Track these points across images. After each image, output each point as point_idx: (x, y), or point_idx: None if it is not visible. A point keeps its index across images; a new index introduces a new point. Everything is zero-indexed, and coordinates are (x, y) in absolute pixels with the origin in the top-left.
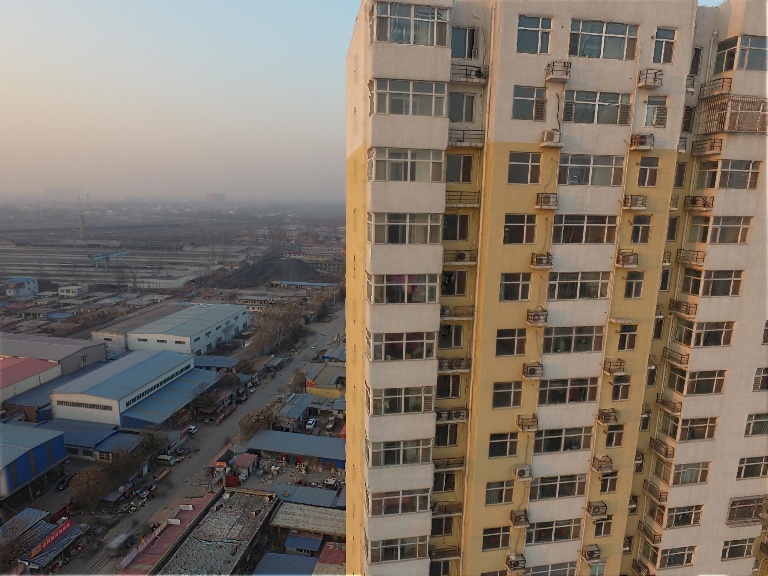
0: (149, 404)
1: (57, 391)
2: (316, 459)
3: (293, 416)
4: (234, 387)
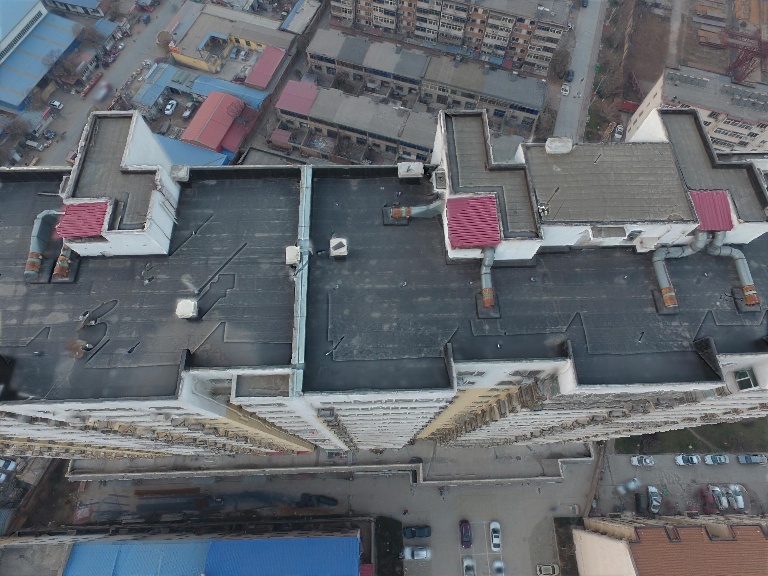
0: (4, 76)
1: None
2: None
3: (148, 101)
4: (97, 44)
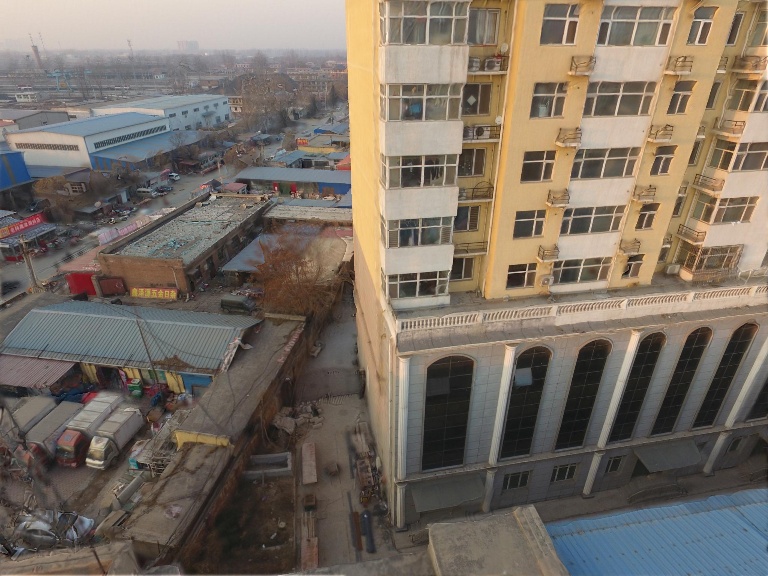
0: (122, 150)
1: (12, 132)
2: (312, 186)
3: (284, 162)
4: (218, 149)
